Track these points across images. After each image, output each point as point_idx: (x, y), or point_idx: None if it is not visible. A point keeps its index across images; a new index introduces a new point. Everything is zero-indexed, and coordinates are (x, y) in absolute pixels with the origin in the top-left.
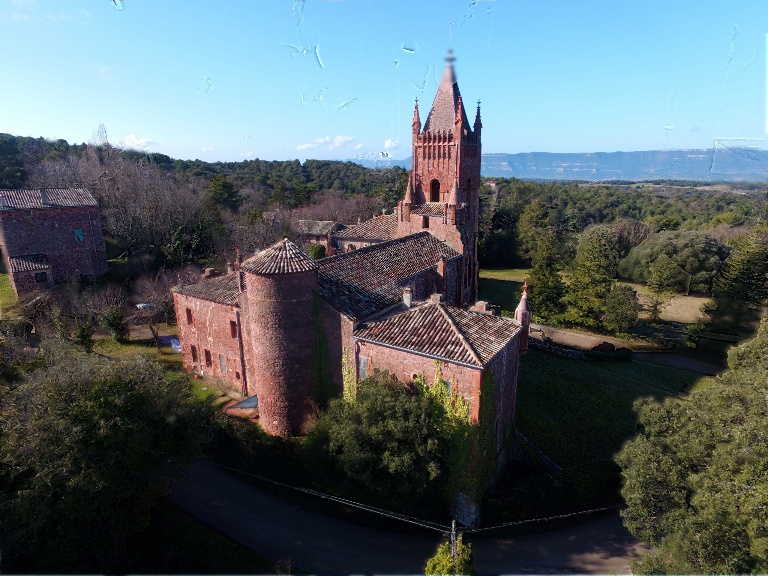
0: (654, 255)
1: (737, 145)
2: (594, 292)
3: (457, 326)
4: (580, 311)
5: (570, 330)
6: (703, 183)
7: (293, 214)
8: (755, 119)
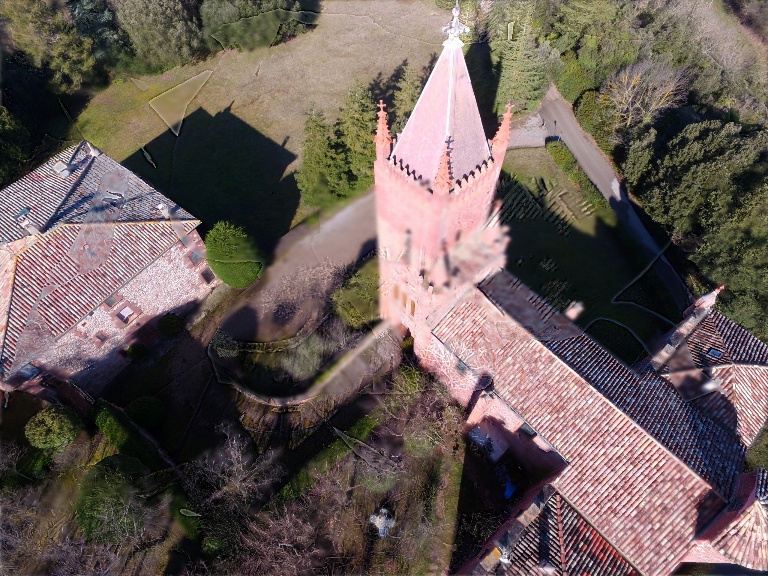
0: (242, 12)
1: None
2: None
3: (759, 364)
4: None
5: None
6: None
7: None
8: None
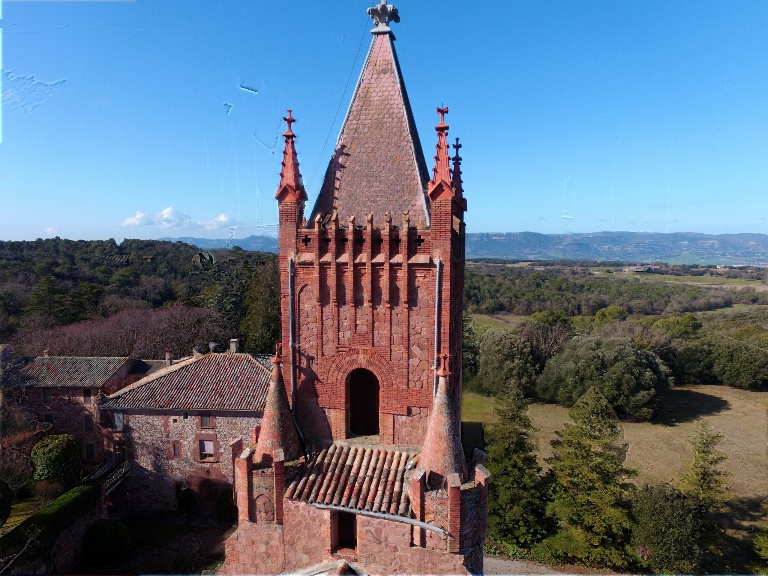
0: (581, 371)
1: (640, 238)
2: (614, 501)
3: None
4: (590, 535)
5: (573, 568)
6: (609, 280)
7: (5, 373)
8: (654, 210)
